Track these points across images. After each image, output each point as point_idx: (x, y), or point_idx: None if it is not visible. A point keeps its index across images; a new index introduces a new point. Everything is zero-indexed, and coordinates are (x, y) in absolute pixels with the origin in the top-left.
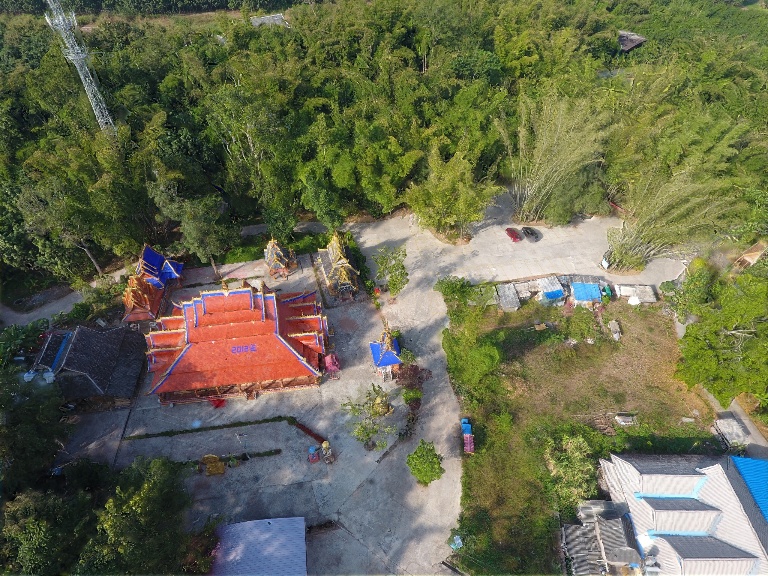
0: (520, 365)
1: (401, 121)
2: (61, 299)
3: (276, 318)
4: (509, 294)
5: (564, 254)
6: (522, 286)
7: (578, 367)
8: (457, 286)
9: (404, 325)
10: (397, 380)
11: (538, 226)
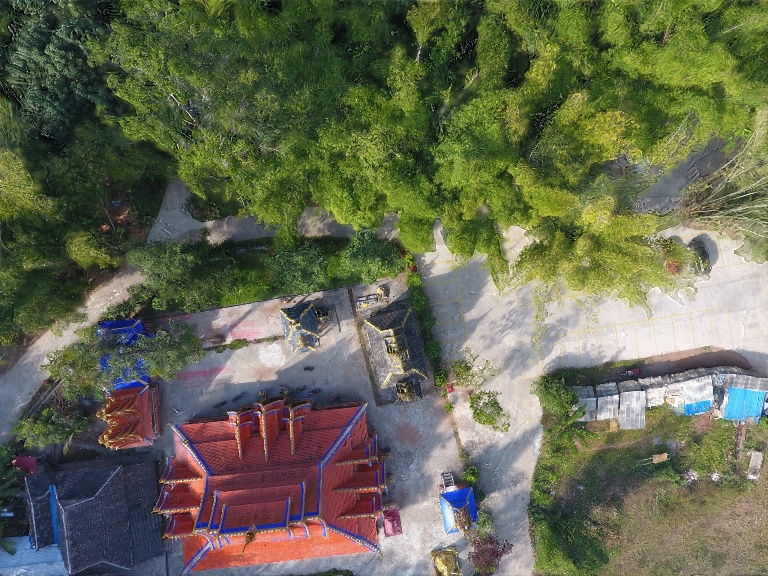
0: (618, 514)
1: (547, 74)
2: (8, 374)
3: (323, 524)
4: (635, 409)
5: (737, 305)
6: (657, 392)
7: (686, 516)
8: (568, 422)
9: (482, 440)
10: (470, 553)
11: (718, 233)
